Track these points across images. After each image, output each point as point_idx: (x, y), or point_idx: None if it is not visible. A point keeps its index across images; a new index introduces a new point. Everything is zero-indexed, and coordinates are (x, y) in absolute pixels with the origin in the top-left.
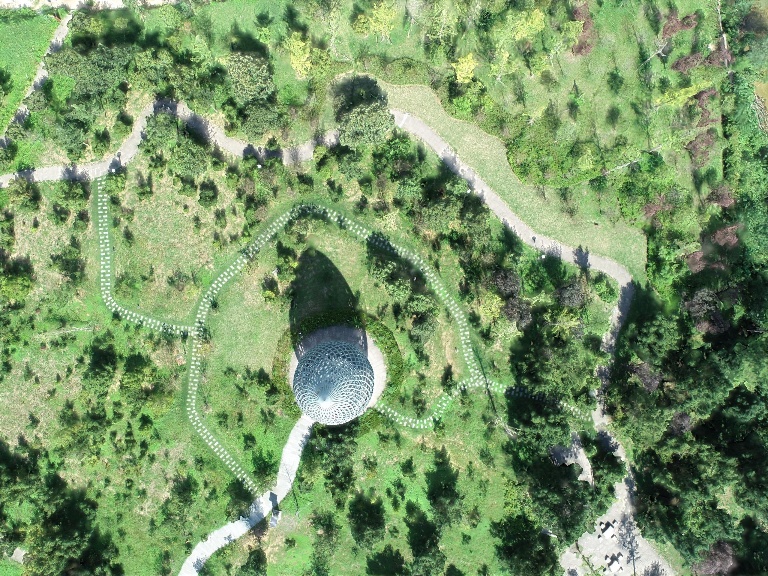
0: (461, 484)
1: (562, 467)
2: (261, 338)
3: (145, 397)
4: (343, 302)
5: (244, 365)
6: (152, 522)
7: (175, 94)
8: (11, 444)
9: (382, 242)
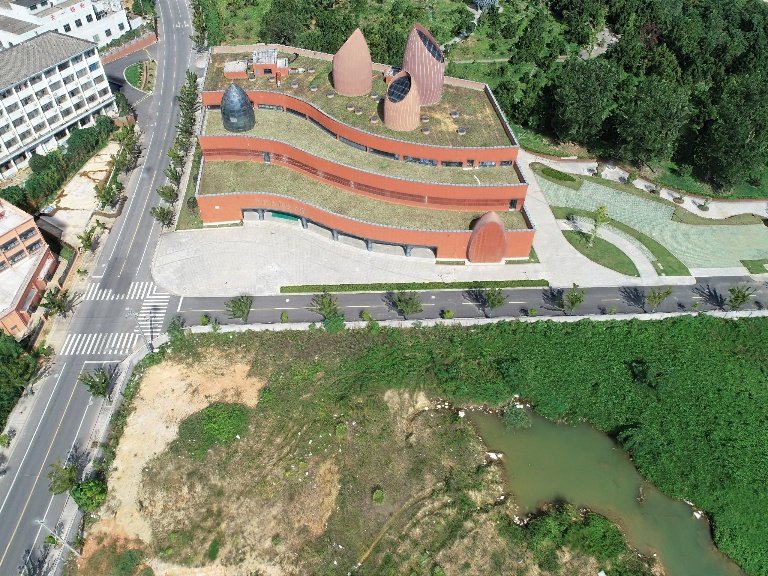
0: None
1: None
2: None
3: None
4: None
5: None
6: None
7: None
8: None
9: None
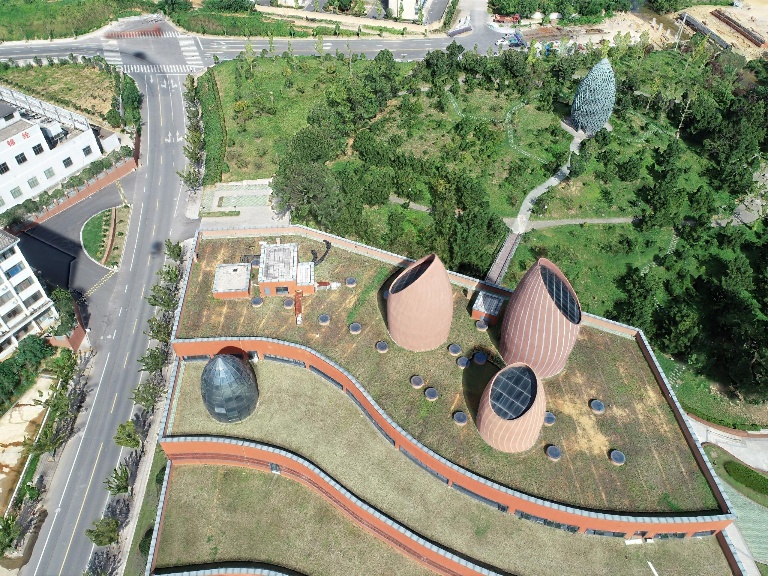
0: None
1: None
2: None
3: None
4: None
5: (536, 129)
6: None
7: (474, 73)
8: None
9: None
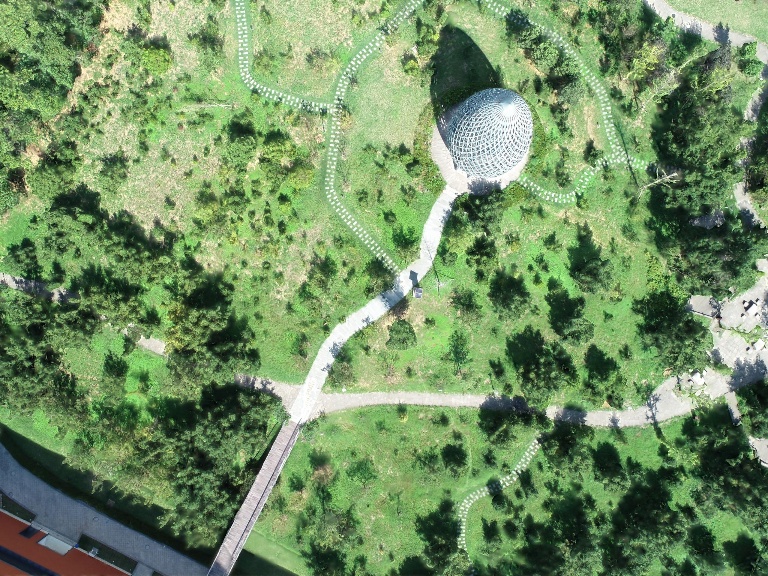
0: (603, 260)
1: (715, 228)
2: (401, 114)
3: (286, 172)
4: (484, 77)
5: (384, 142)
6: (289, 306)
7: None
8: (146, 228)
9: (521, 20)
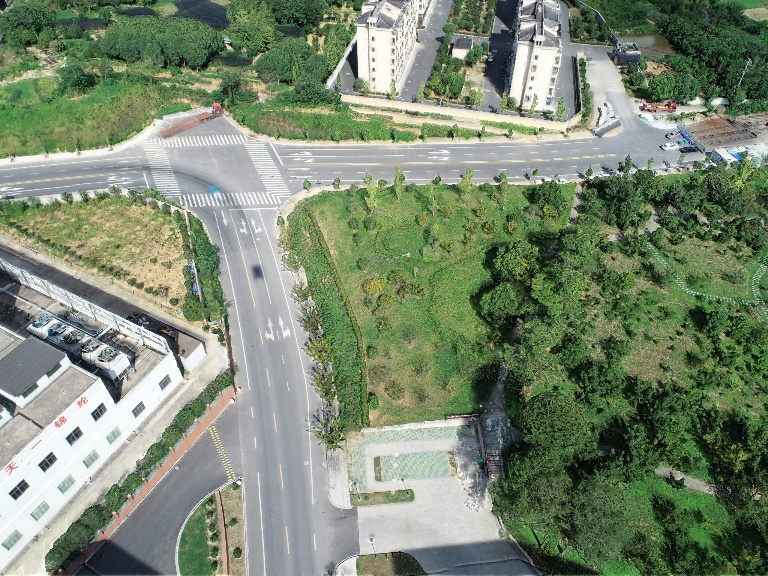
0: None
1: None
2: None
3: (752, 338)
4: None
5: None
6: None
7: (664, 205)
8: None
9: None
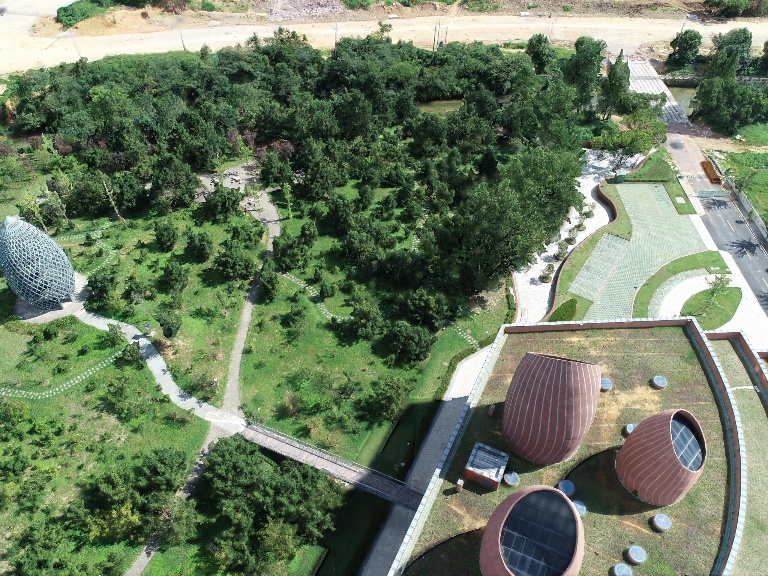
0: None
1: None
2: (3, 345)
3: (8, 423)
4: (3, 297)
5: (20, 356)
6: (134, 431)
7: None
8: (5, 569)
9: None
